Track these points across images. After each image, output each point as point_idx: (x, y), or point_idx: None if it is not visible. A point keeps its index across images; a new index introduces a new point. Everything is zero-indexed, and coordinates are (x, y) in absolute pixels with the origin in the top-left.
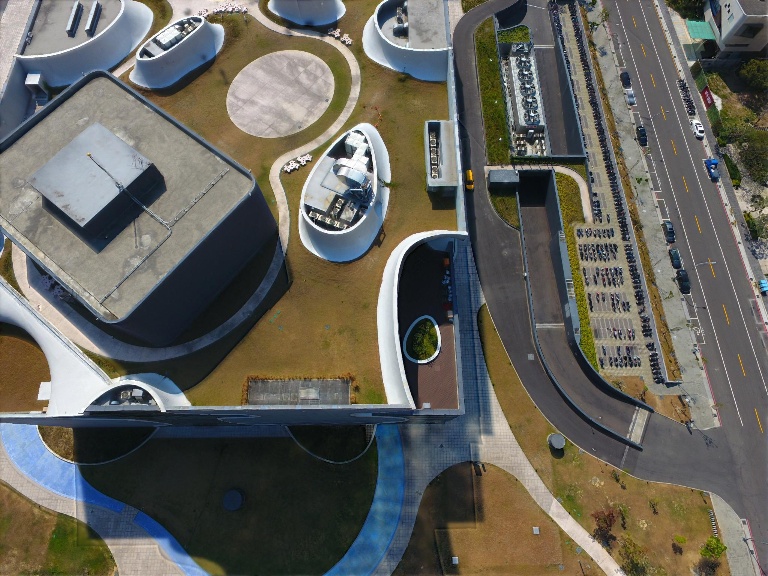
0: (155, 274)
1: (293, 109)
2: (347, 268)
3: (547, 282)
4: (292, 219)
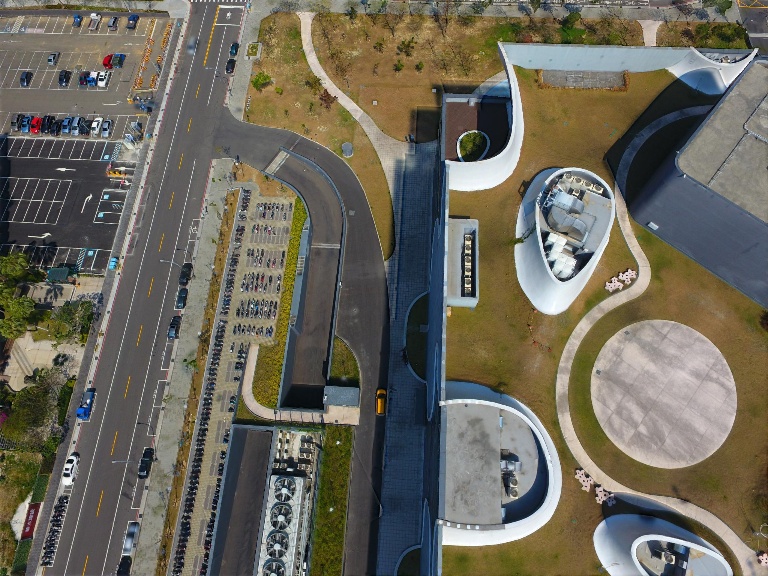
0: (743, 95)
1: (641, 361)
2: (554, 164)
3: (316, 289)
4: (615, 217)
